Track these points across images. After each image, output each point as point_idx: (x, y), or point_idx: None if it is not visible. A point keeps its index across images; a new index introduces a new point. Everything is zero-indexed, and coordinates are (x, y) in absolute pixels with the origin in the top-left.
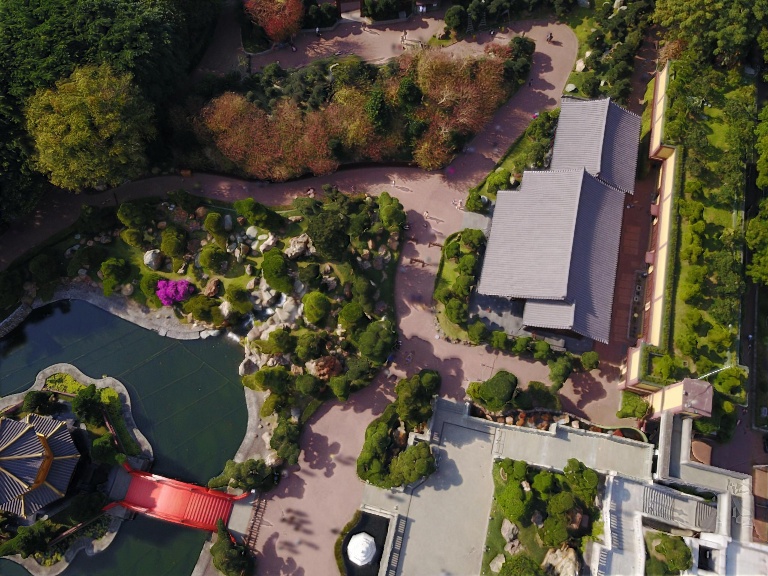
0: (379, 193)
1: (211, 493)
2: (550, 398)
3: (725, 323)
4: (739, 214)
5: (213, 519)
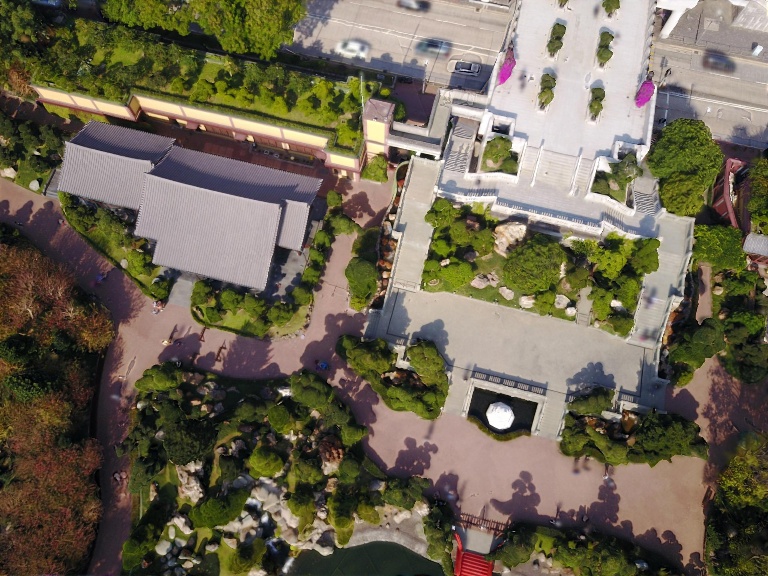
0: (132, 394)
1: (459, 573)
2: (369, 235)
3: (311, 85)
4: (209, 57)
5: (482, 570)
